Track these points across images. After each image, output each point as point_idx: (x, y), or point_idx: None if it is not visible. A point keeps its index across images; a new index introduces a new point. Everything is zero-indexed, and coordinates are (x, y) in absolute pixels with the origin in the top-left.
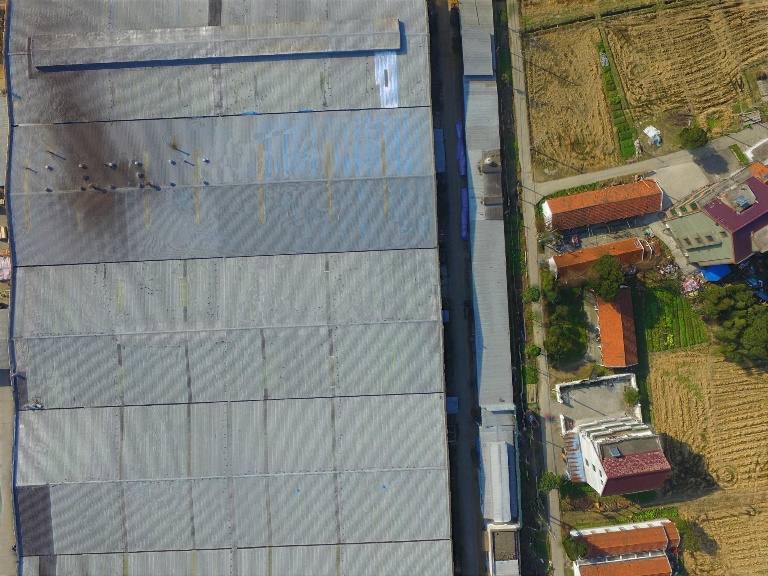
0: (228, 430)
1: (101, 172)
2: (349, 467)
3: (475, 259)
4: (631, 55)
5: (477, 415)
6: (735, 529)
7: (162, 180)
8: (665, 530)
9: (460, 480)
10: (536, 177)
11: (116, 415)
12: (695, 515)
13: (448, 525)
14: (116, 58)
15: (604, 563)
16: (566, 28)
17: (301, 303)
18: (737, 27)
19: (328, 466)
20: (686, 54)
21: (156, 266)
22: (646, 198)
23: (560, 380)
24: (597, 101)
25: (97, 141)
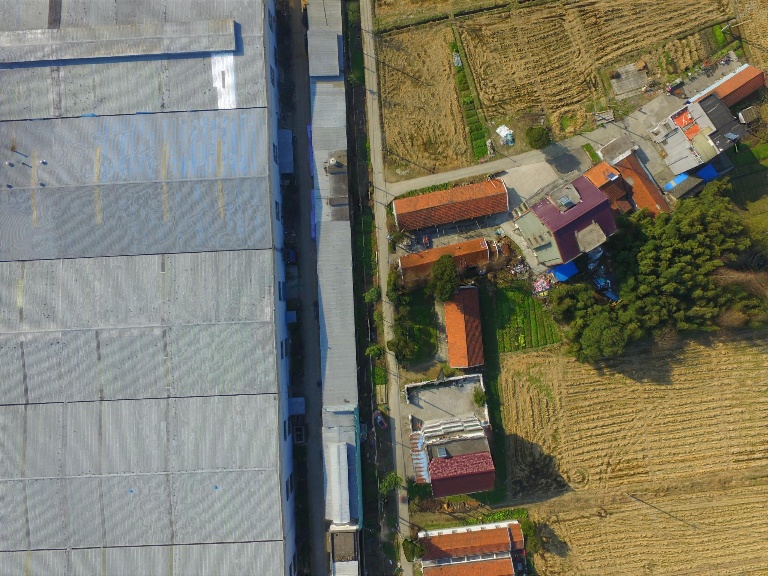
0: (63, 431)
1: None
2: (181, 468)
3: (320, 260)
4: (485, 55)
5: None
6: (586, 531)
7: None
8: (509, 531)
9: (309, 481)
10: (388, 177)
11: None
12: (546, 516)
13: (281, 526)
14: None
15: (448, 564)
16: (419, 28)
17: (136, 304)
18: (592, 26)
19: (161, 467)
20: (540, 53)
21: None
22: (491, 198)
23: (410, 381)
24: (450, 101)
25: None
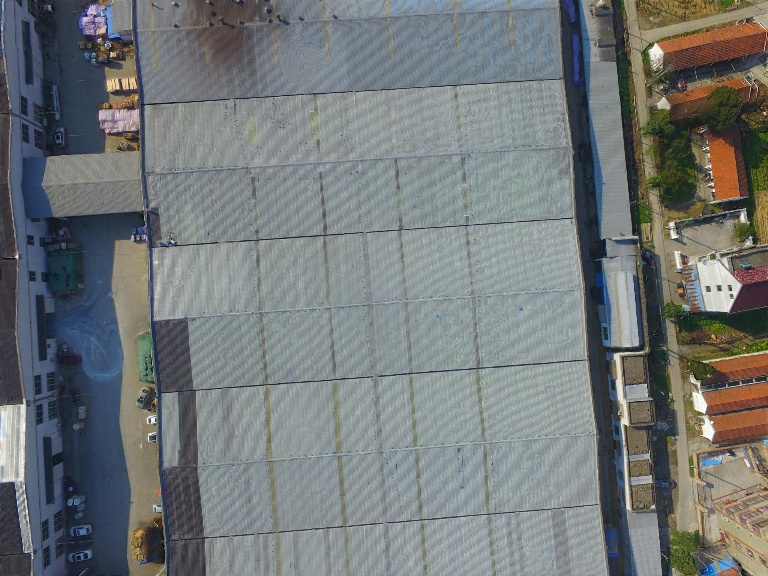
0: (365, 260)
1: (228, 8)
2: (487, 291)
3: (591, 98)
4: None
5: (596, 252)
6: None
7: (290, 15)
8: None
9: None
10: (642, 25)
11: (251, 249)
12: None
13: (584, 345)
14: None
15: (725, 388)
16: None
17: (433, 133)
18: None
19: (466, 291)
20: None
21: (286, 101)
22: (752, 37)
23: (673, 219)
24: None
25: None
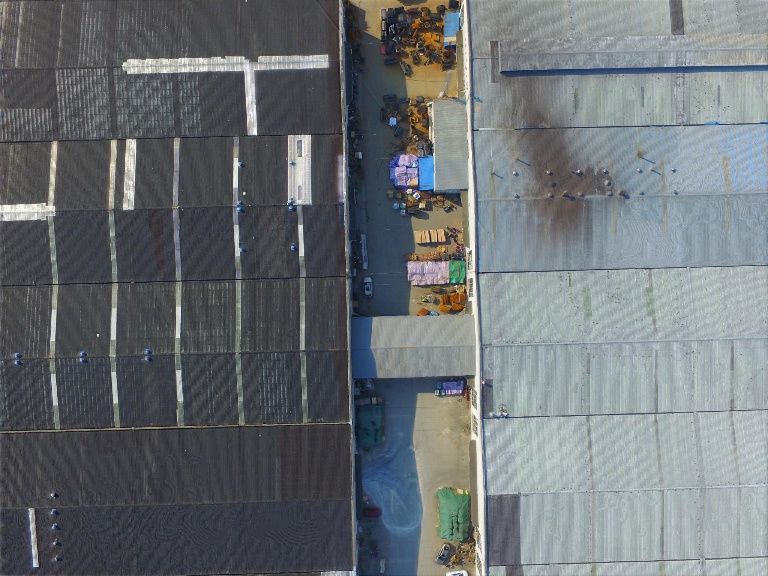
0: (697, 441)
1: (567, 179)
2: None
3: None
4: None
5: None
6: None
7: (630, 188)
8: None
9: None
10: None
11: (582, 424)
12: None
13: None
14: (583, 64)
15: None
16: None
17: None
18: None
19: None
20: None
21: (620, 275)
22: None
23: None
24: None
25: (560, 147)
